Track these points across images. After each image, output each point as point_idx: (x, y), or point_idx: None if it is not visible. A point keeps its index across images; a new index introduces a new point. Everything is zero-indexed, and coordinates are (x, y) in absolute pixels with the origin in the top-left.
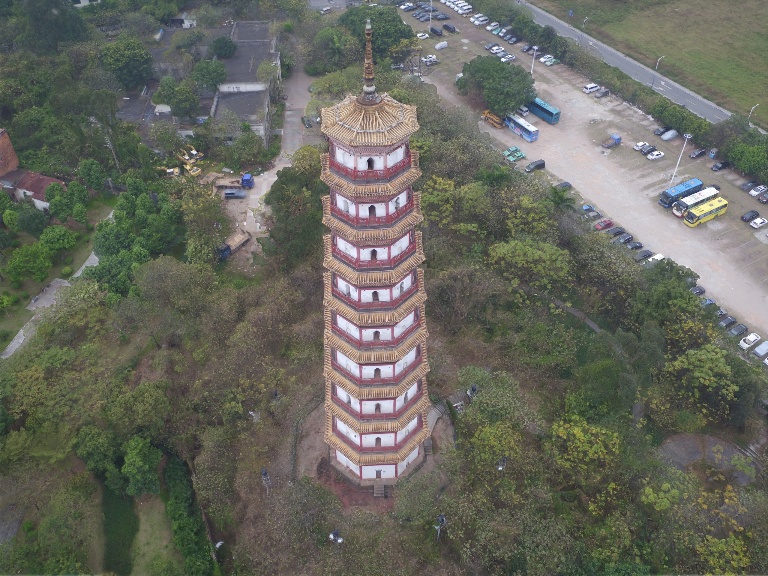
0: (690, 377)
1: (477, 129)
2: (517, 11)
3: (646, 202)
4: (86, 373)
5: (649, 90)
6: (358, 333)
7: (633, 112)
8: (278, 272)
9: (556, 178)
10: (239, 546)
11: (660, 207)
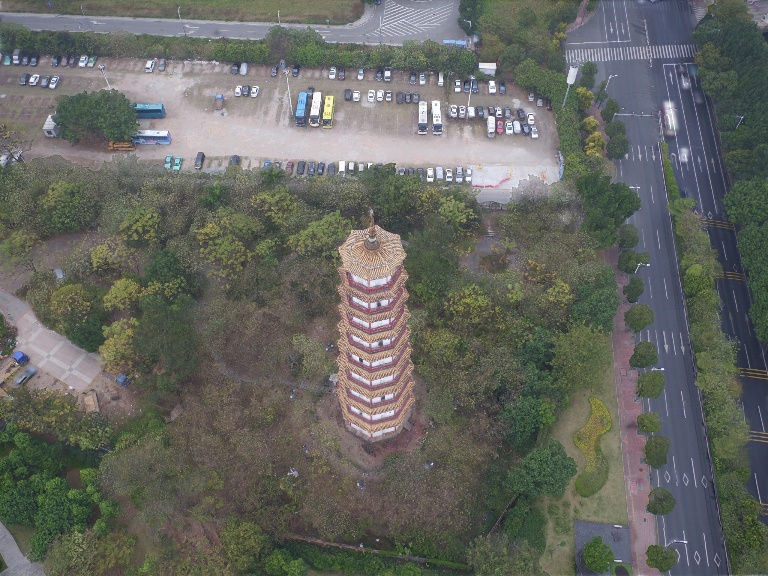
0: (454, 224)
1: (148, 168)
2: (8, 32)
3: (290, 131)
4: (182, 573)
5: (188, 39)
6: (391, 359)
7: (200, 66)
8: (181, 388)
9: (221, 158)
10: (390, 527)
11: (300, 128)
